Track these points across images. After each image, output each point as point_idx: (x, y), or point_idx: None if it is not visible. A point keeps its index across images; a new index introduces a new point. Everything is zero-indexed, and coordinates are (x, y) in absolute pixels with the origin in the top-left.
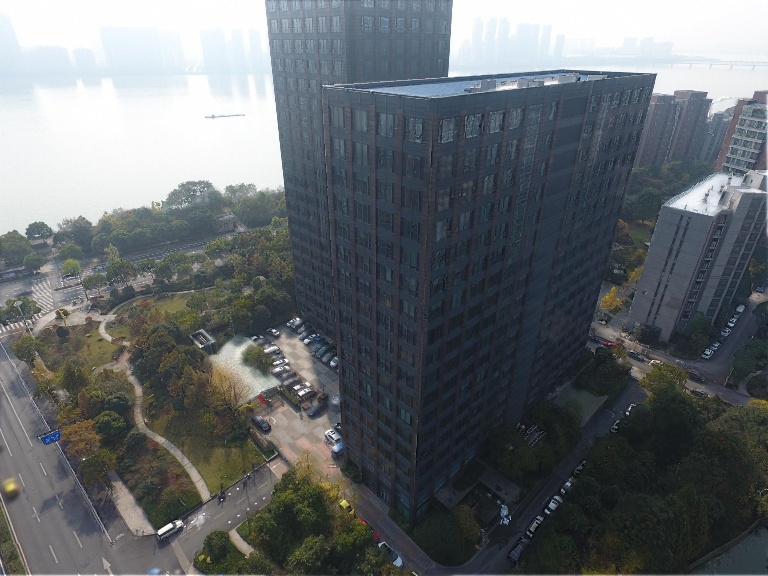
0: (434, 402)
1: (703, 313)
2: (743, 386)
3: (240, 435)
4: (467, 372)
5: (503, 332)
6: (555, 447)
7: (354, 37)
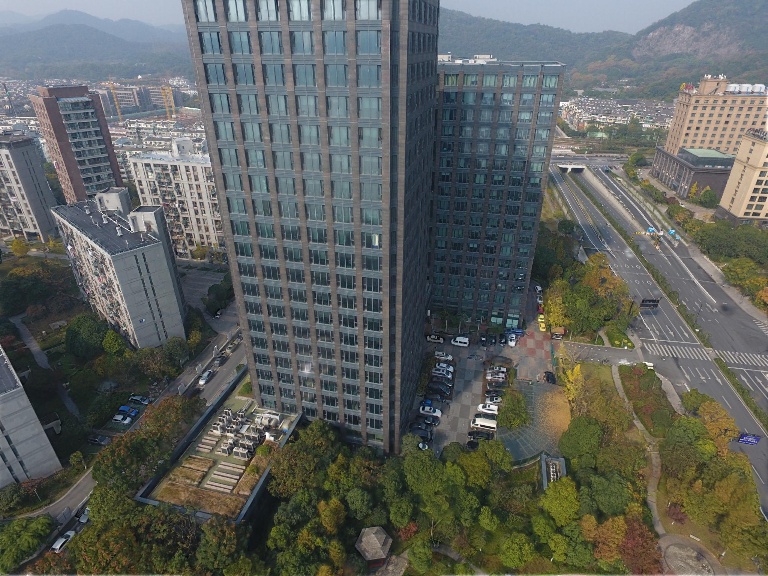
0: None
1: None
2: None
3: None
4: None
5: None
6: None
7: None
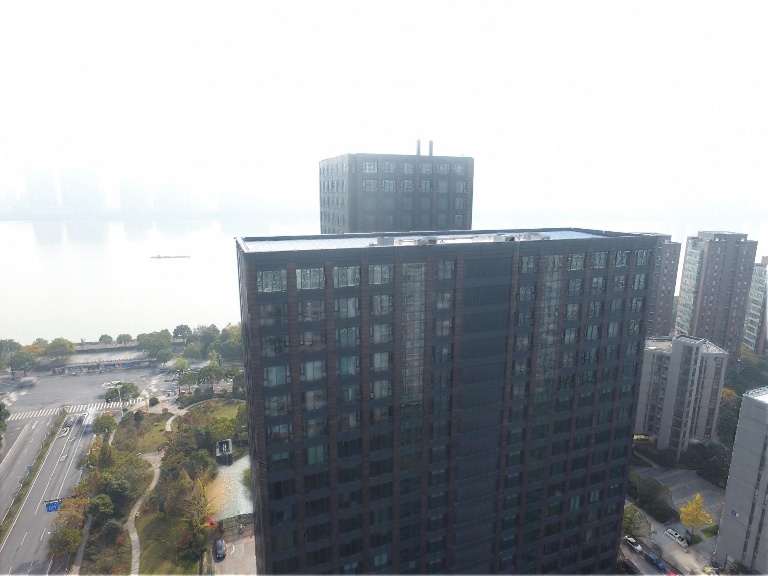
0: (294, 573)
1: None
2: None
3: (192, 555)
4: (351, 548)
5: (414, 510)
6: None
7: (356, 196)
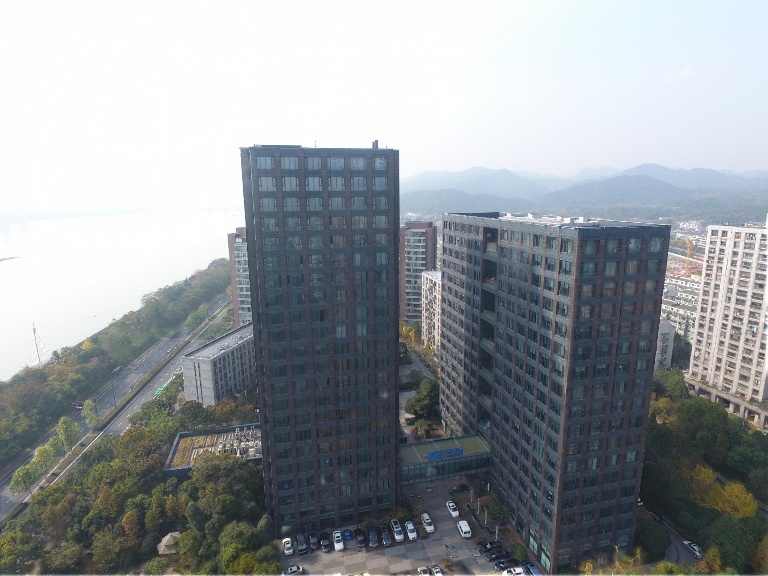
0: None
1: None
2: None
3: None
4: None
5: None
6: None
7: (394, 194)
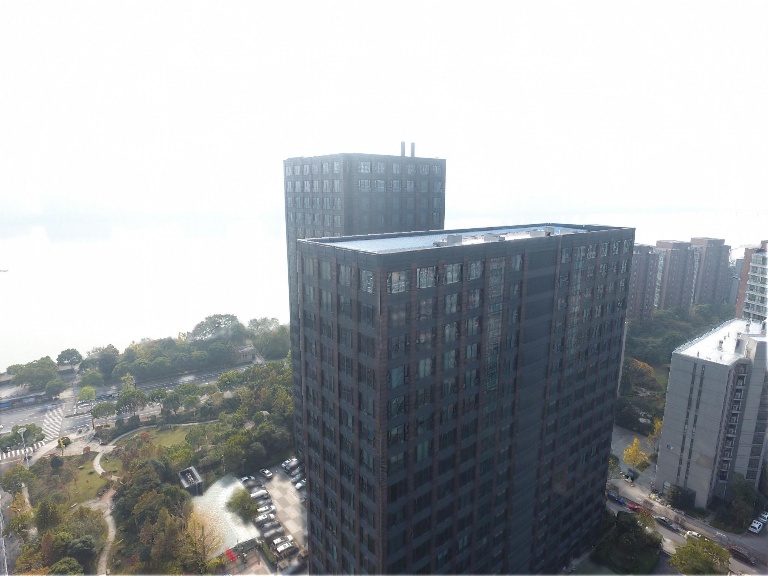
0: (402, 573)
1: (742, 475)
2: None
3: None
4: (444, 537)
5: (487, 489)
6: None
7: (352, 196)
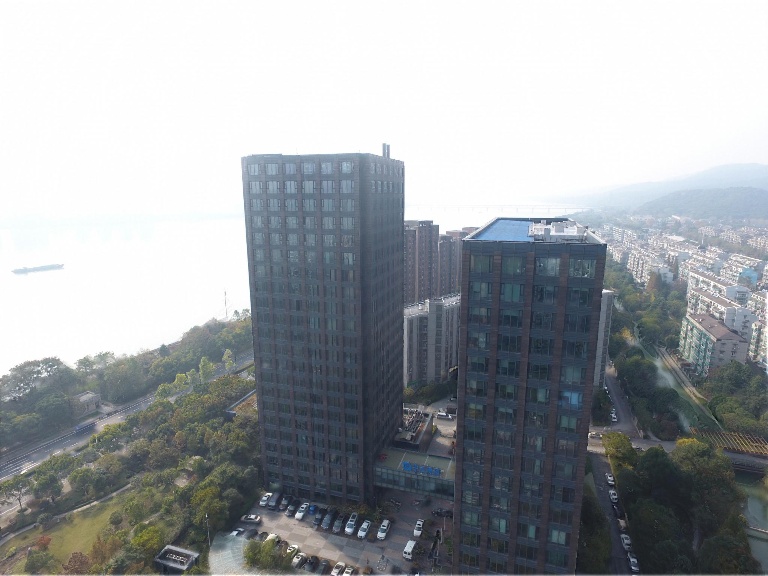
0: None
1: (598, 386)
2: (651, 435)
3: None
4: None
5: None
6: (605, 530)
7: (364, 197)
